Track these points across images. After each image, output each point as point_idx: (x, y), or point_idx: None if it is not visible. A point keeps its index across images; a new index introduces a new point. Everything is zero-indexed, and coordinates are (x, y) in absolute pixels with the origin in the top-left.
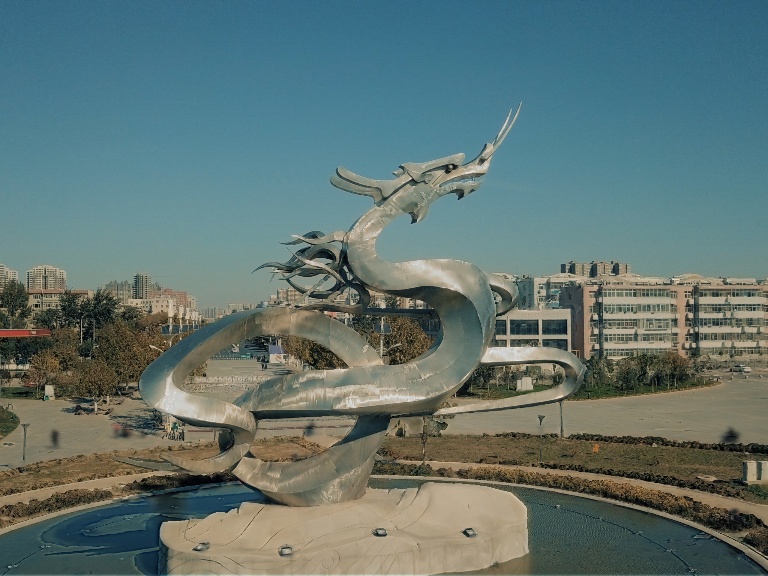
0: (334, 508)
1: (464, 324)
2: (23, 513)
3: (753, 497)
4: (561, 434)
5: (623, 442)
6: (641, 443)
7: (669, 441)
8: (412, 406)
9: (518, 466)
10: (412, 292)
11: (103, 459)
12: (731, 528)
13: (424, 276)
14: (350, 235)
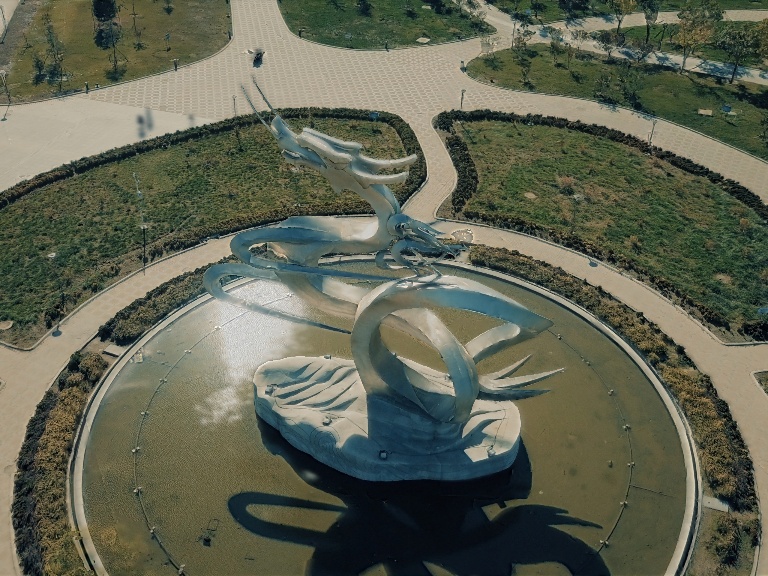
0: None
1: None
2: None
3: None
4: None
5: None
6: None
7: None
8: None
9: None
10: None
11: None
12: None
13: None
14: None
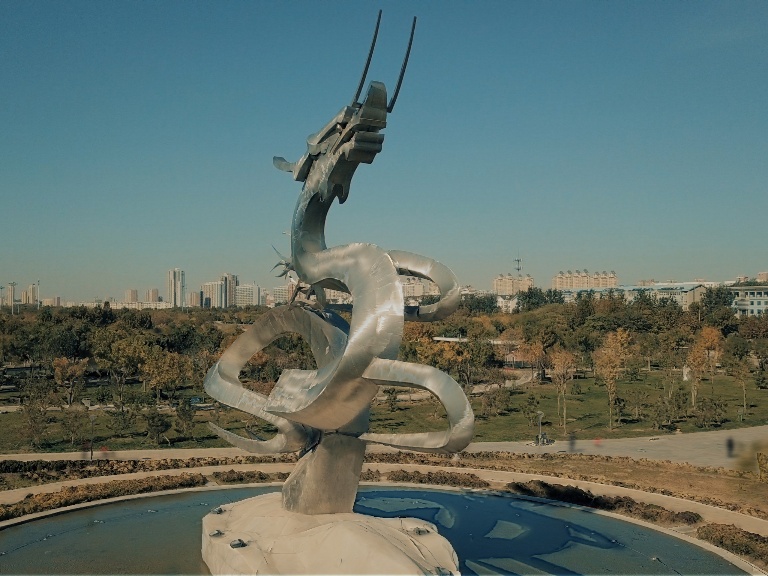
0: (279, 513)
1: None
2: (392, 477)
3: None
4: None
5: None
6: None
7: None
8: (300, 419)
9: None
10: (336, 286)
11: (636, 465)
12: None
13: (328, 266)
14: None
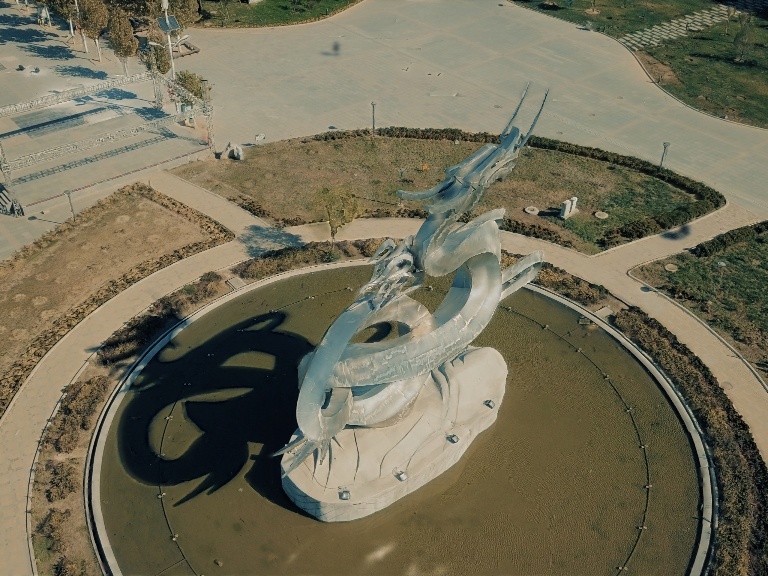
0: (409, 423)
1: (488, 271)
2: (73, 446)
3: (578, 241)
4: (373, 131)
5: (429, 138)
6: (444, 138)
7: (465, 133)
8: None
9: (390, 218)
10: None
11: None
12: (594, 304)
13: (469, 252)
14: (428, 249)
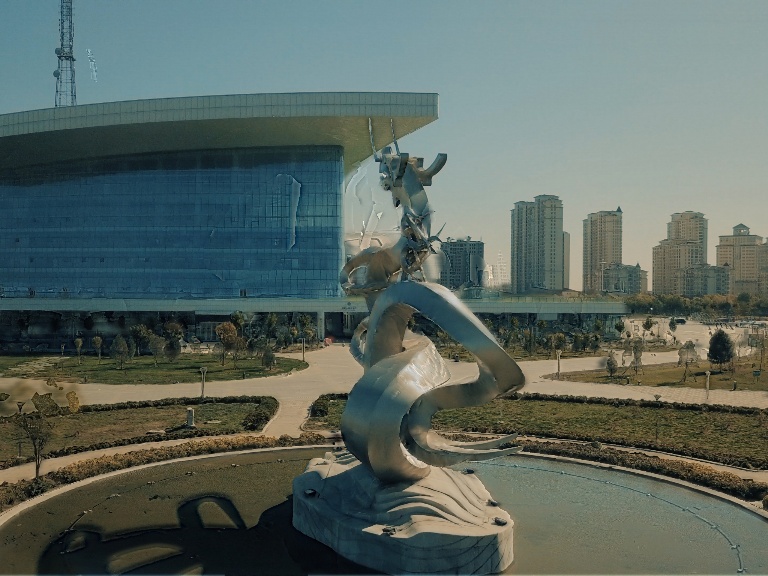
0: None
1: None
2: None
3: None
4: None
5: None
6: None
7: None
8: None
9: (34, 463)
10: None
11: None
12: None
13: None
14: None
